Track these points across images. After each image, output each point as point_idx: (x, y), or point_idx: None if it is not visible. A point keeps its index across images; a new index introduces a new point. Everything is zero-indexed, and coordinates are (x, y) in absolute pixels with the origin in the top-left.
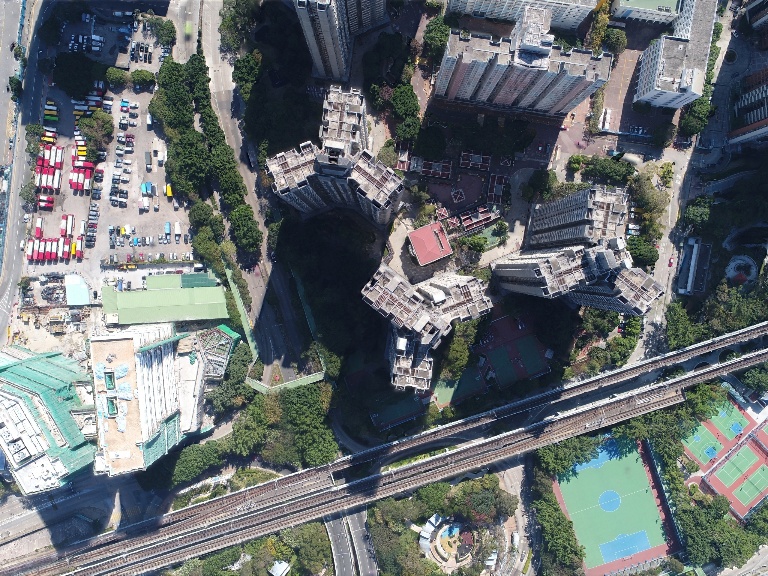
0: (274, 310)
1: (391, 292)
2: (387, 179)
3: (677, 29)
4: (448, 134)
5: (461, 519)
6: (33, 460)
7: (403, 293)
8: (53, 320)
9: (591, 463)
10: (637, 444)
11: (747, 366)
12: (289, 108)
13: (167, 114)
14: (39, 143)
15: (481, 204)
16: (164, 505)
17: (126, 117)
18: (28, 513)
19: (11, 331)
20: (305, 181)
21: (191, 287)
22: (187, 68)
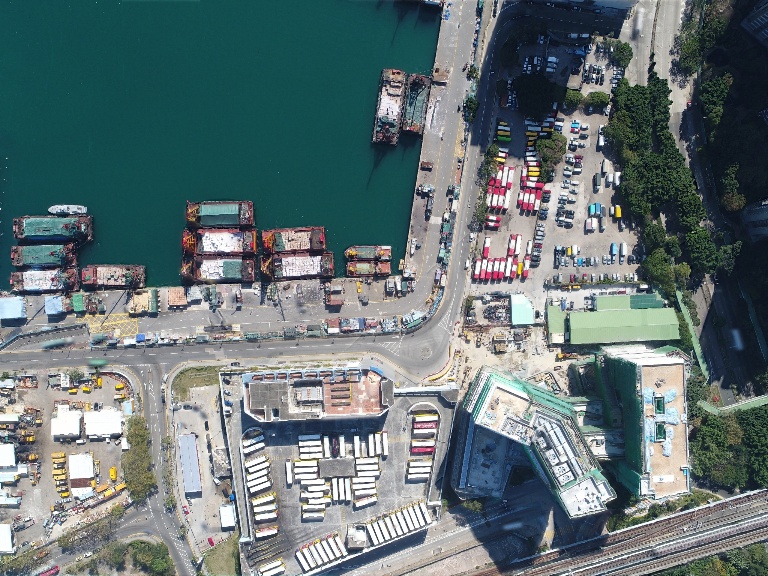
0: (715, 331)
1: None
2: None
3: None
4: None
5: None
6: (579, 483)
7: None
8: (498, 339)
9: None
10: None
11: None
12: None
13: (630, 136)
14: (496, 164)
15: None
16: (598, 524)
17: (577, 138)
18: (461, 530)
19: (452, 349)
20: None
21: (640, 308)
22: (651, 91)
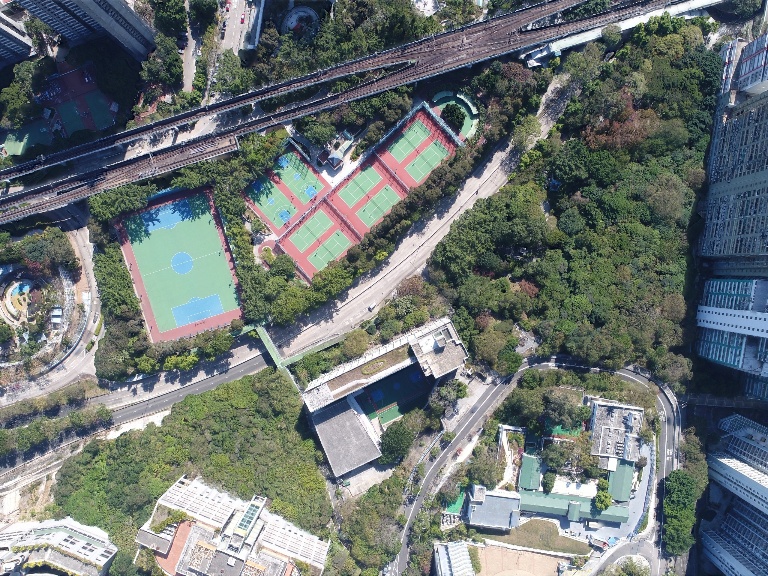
0: None
1: None
2: None
3: None
4: None
5: (29, 275)
6: None
7: None
8: None
9: (163, 224)
10: (210, 205)
11: (299, 115)
12: None
13: None
14: None
15: None
16: None
17: None
18: None
19: None
20: None
21: None
22: None
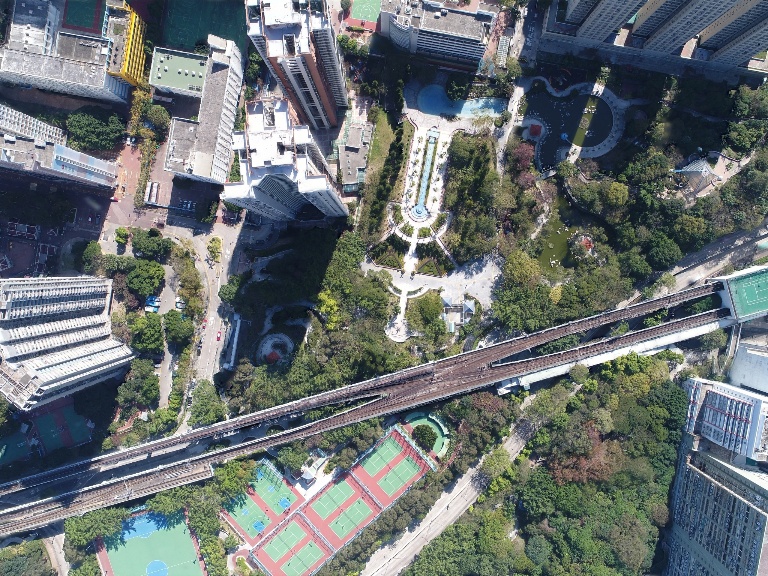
0: None
1: None
2: None
3: None
4: None
5: None
6: None
7: None
8: None
9: (139, 532)
10: (185, 515)
11: (272, 445)
12: None
13: None
14: None
15: (29, 272)
16: None
17: None
18: None
19: None
20: None
21: None
22: None
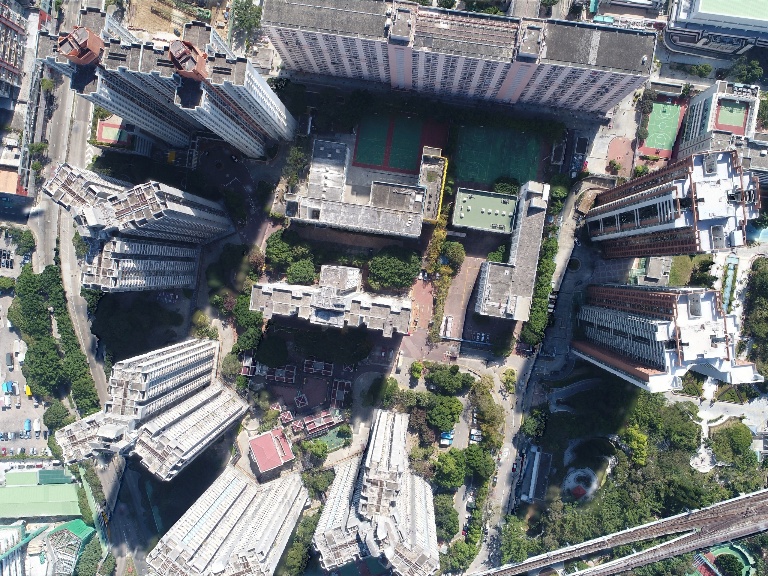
0: (128, 505)
1: (173, 561)
2: (168, 453)
3: (512, 245)
4: (293, 339)
5: None
6: None
7: (185, 562)
8: None
9: None
10: None
11: None
12: (136, 318)
13: (22, 323)
14: None
15: (325, 408)
16: None
17: None
18: None
19: None
20: (92, 453)
21: (47, 483)
22: (41, 279)
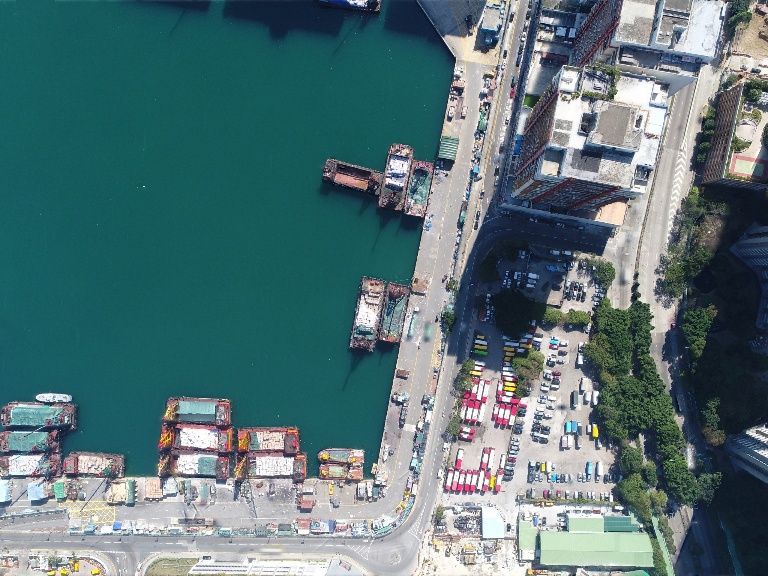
0: (693, 557)
1: None
2: None
3: None
4: None
5: None
6: None
7: None
8: (468, 552)
9: None
10: None
11: None
12: None
13: (609, 361)
14: (471, 379)
15: None
16: None
17: (556, 355)
18: None
19: (421, 557)
20: None
21: (614, 531)
22: (632, 316)
